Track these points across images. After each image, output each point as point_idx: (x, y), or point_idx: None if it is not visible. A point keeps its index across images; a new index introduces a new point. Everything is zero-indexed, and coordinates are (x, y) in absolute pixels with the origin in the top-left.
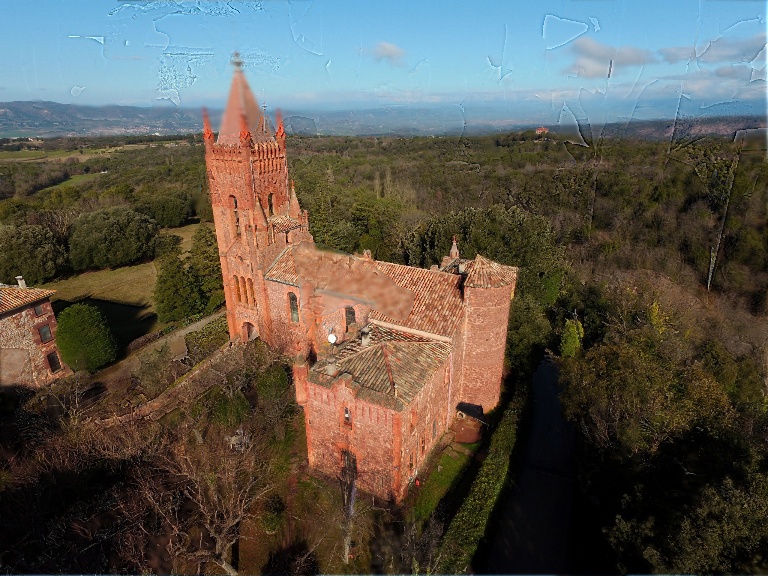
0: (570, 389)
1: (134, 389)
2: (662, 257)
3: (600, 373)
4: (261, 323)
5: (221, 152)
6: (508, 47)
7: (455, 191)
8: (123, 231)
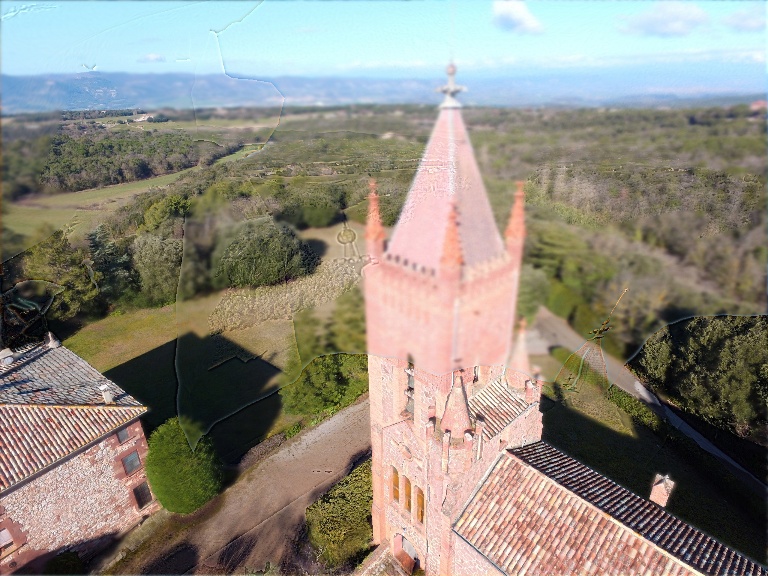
0: None
1: None
2: None
3: None
4: (432, 575)
5: None
6: None
7: None
8: None
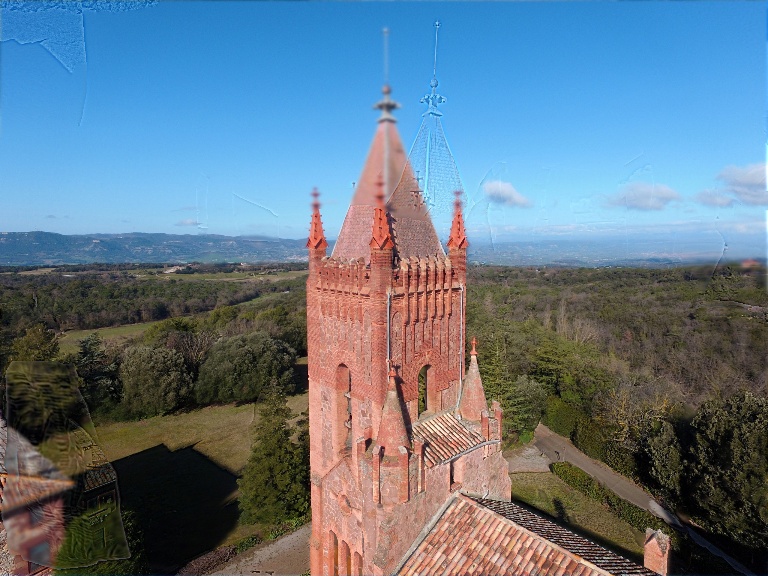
0: None
1: None
2: None
3: None
4: None
5: (333, 275)
6: None
7: (718, 347)
8: (256, 362)
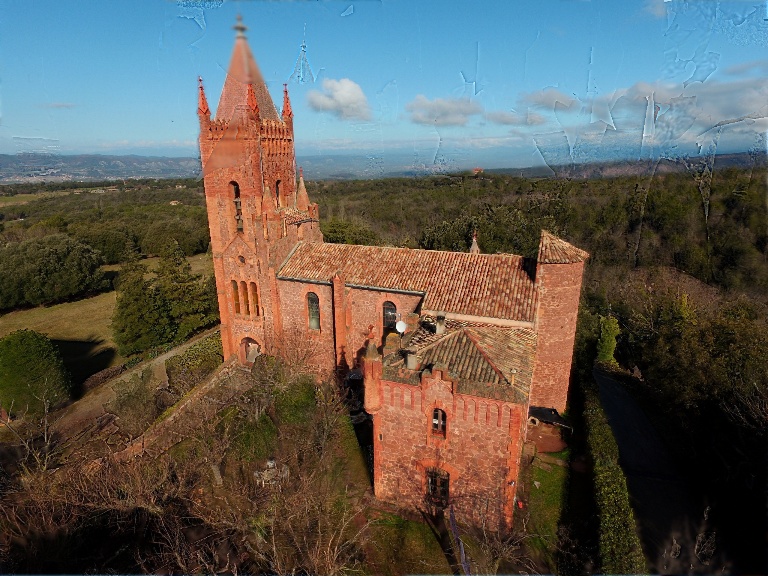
0: (678, 372)
1: (99, 432)
2: (655, 260)
3: (710, 350)
4: (269, 335)
5: (220, 129)
6: (481, 64)
7: (436, 206)
8: (62, 261)
